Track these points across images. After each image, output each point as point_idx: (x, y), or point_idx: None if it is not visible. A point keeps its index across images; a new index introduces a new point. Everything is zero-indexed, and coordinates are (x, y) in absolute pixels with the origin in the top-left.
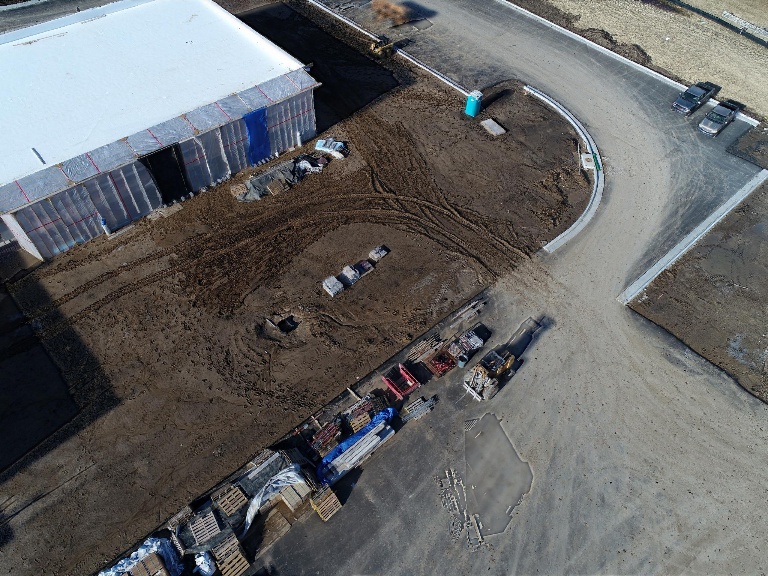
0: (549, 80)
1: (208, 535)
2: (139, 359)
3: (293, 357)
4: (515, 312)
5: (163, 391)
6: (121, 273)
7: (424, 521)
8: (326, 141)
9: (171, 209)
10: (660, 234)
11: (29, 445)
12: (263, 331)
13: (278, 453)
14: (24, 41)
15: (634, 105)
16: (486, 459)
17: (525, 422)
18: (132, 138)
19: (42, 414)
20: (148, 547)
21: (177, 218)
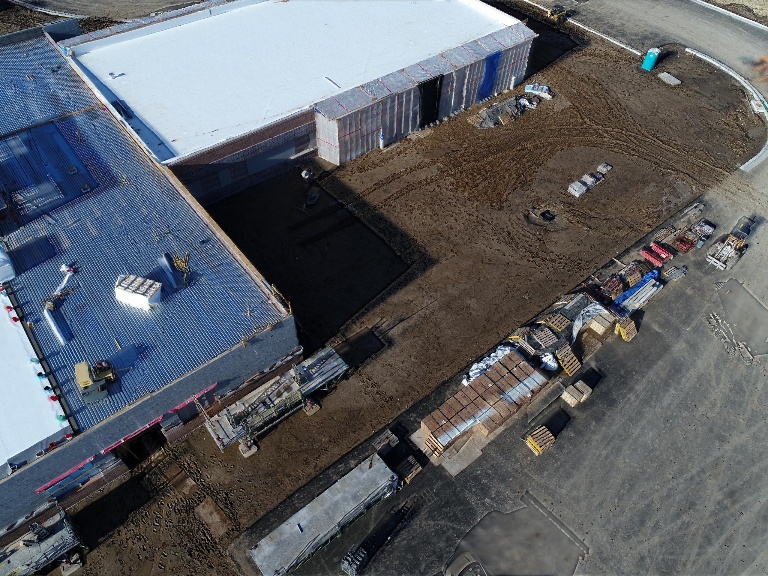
0: (706, 44)
1: (550, 341)
2: (441, 234)
3: (561, 237)
4: (731, 212)
5: (468, 256)
6: (403, 176)
7: (704, 345)
8: (534, 85)
9: (424, 132)
10: None
11: (382, 286)
12: (529, 219)
13: (582, 294)
14: None
15: None
16: (739, 308)
17: (763, 285)
18: (408, 69)
19: (382, 267)
20: (503, 350)
21: (432, 139)
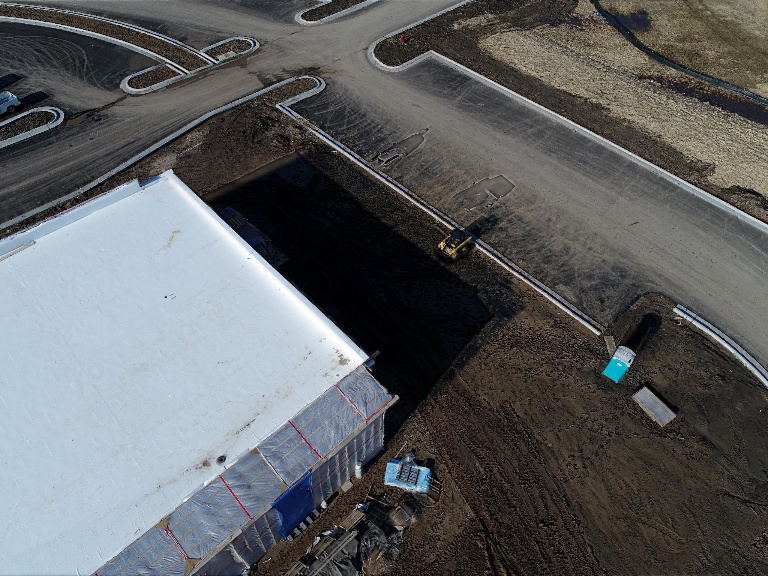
0: (706, 292)
1: None
2: None
3: None
4: None
5: None
6: None
7: None
8: (401, 466)
9: None
10: None
11: None
12: None
13: None
14: None
15: None
16: None
17: None
18: None
19: None
20: None
21: None
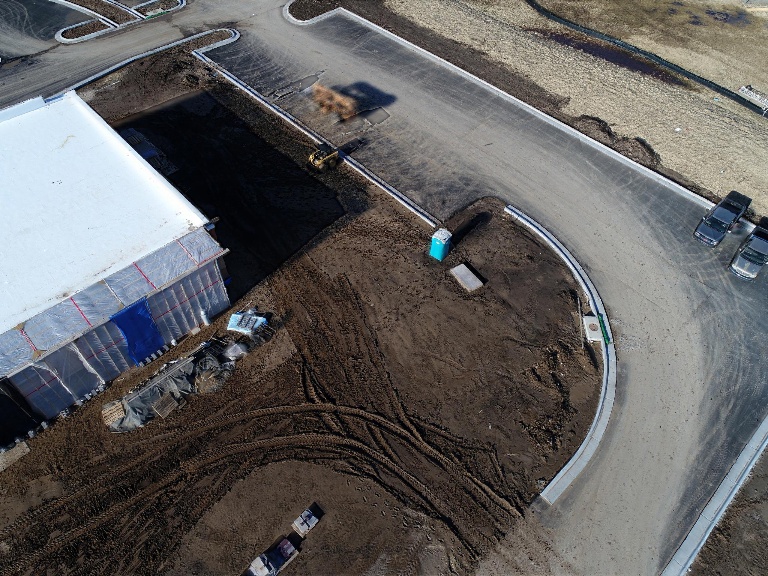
0: (536, 196)
1: None
2: None
3: None
4: None
5: None
6: None
7: None
8: (242, 316)
9: (11, 454)
10: (700, 458)
11: None
12: None
13: None
14: None
15: (645, 232)
16: None
17: None
18: None
19: None
20: None
21: (18, 471)
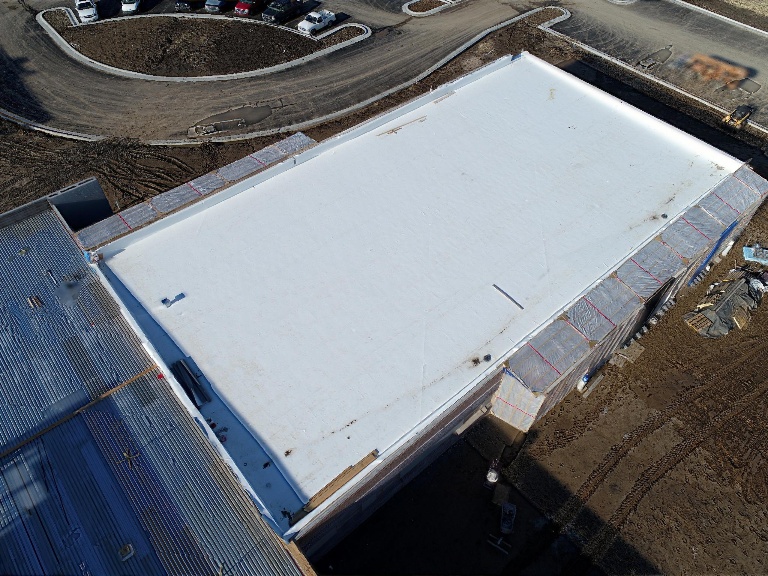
0: None
1: None
2: None
3: None
4: None
5: None
6: (630, 450)
7: None
8: (755, 249)
9: (632, 350)
10: None
11: None
12: None
13: None
14: (386, 129)
15: None
16: None
17: None
18: (623, 273)
19: None
20: None
21: (646, 364)
